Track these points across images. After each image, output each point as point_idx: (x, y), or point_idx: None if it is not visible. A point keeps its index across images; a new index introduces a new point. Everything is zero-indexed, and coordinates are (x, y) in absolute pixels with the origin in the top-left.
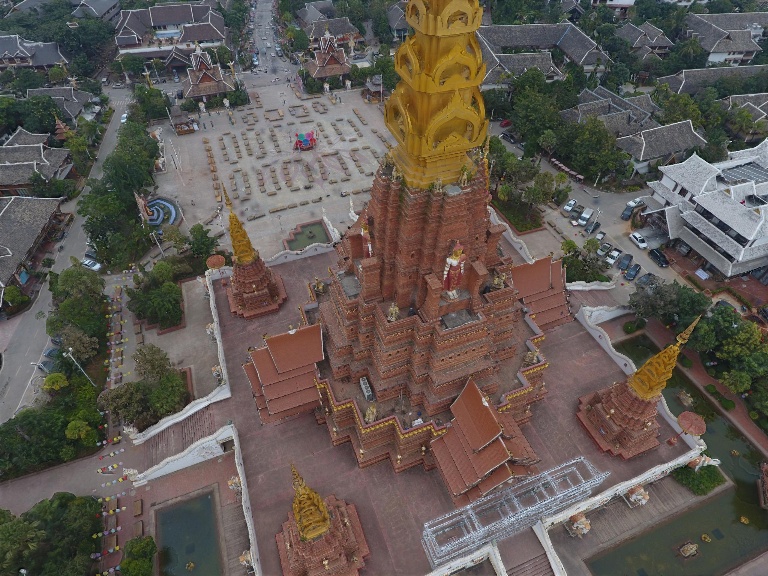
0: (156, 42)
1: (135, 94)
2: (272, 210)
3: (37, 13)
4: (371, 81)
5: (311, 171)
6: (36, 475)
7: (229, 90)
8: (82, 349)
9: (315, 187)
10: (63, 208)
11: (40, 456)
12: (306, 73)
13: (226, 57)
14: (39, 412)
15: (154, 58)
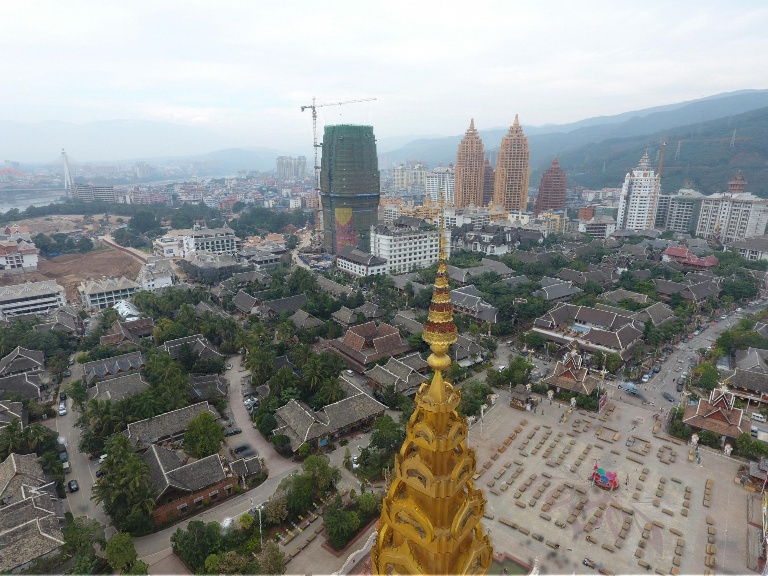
0: (566, 331)
1: (510, 362)
2: (502, 520)
3: (510, 287)
4: (759, 462)
5: (582, 511)
6: (185, 569)
7: (583, 392)
8: (273, 513)
9: (567, 530)
10: (391, 413)
11: (189, 559)
12: (679, 414)
13: (612, 364)
14: (220, 531)
15: (555, 341)
